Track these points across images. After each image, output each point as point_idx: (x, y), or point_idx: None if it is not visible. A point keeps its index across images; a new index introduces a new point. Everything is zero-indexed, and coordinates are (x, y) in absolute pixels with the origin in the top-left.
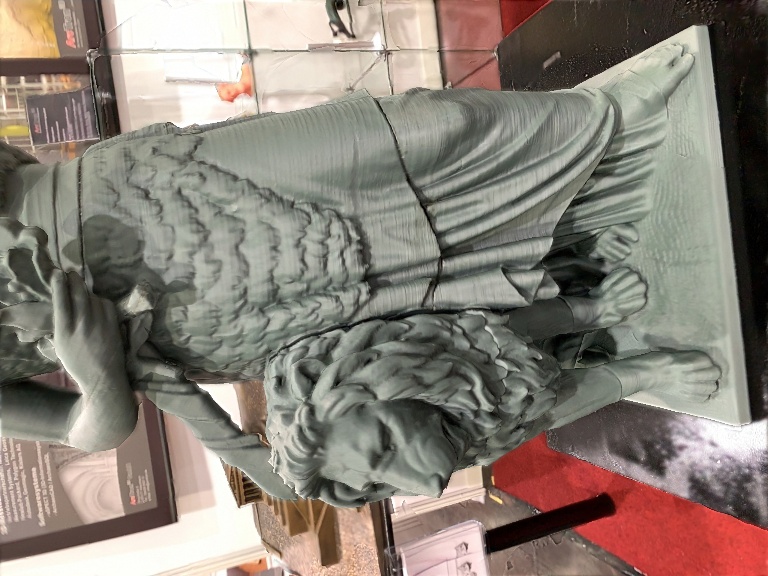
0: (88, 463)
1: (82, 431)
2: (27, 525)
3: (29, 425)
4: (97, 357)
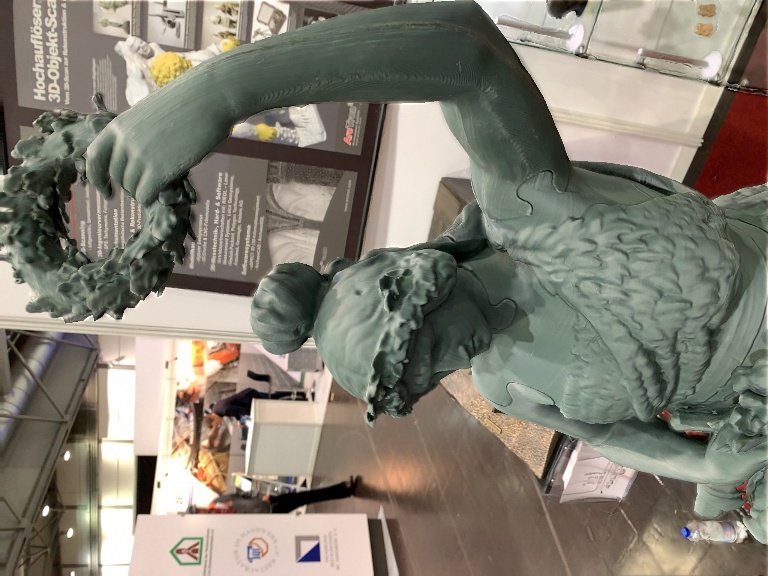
0: (293, 236)
1: (636, 462)
2: (232, 270)
3: (582, 433)
4: (756, 471)
